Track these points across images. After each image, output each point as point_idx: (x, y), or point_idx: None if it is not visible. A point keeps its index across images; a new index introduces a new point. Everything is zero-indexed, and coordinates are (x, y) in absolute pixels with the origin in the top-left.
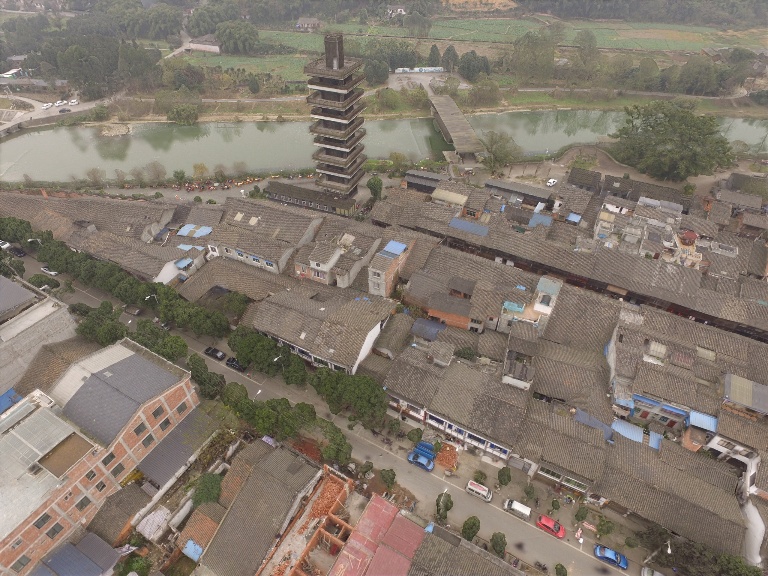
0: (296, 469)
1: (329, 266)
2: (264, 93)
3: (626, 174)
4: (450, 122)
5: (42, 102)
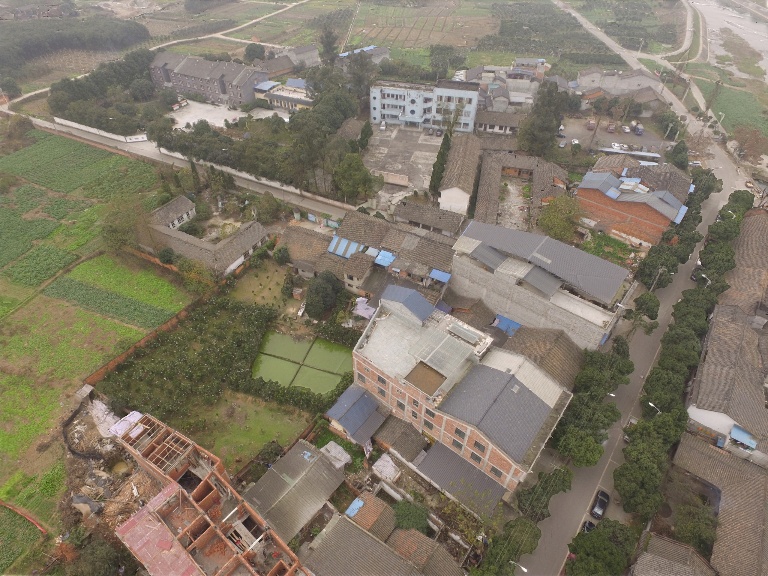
0: None
1: None
2: None
3: None
4: None
5: None
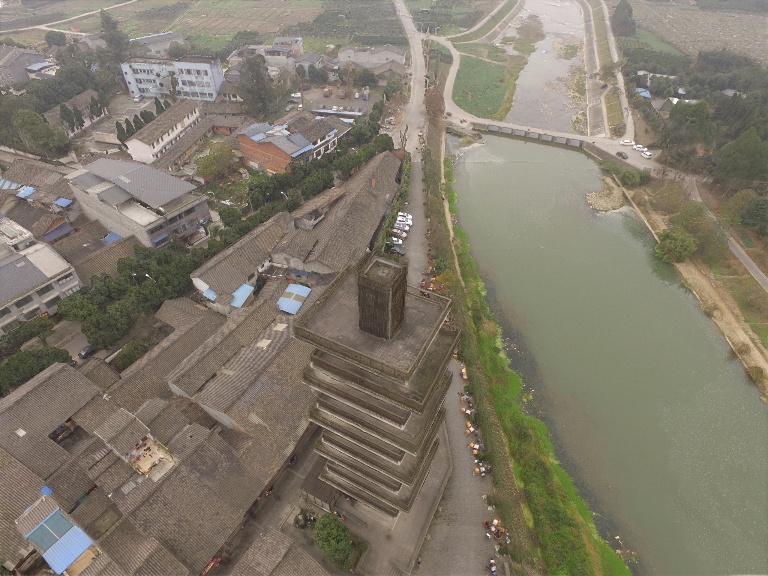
0: None
1: None
2: None
3: None
4: None
5: (635, 138)
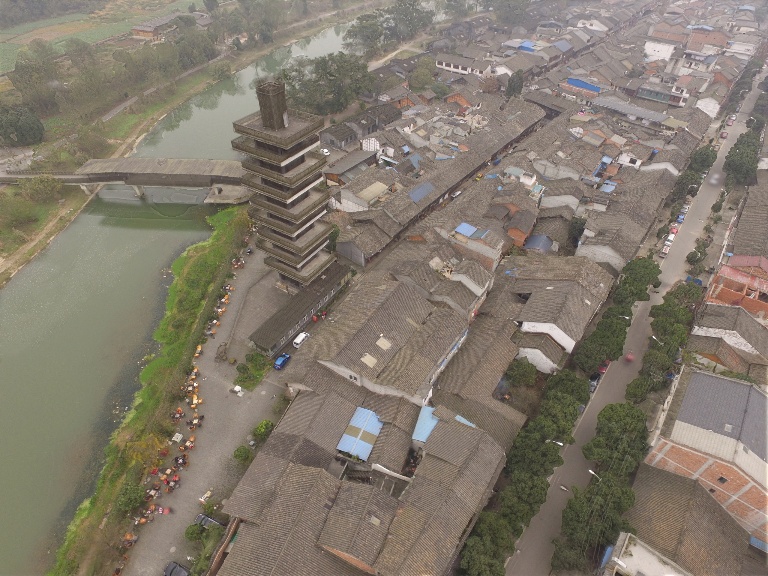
0: (719, 312)
1: None
2: None
3: (332, 119)
4: (182, 169)
5: None
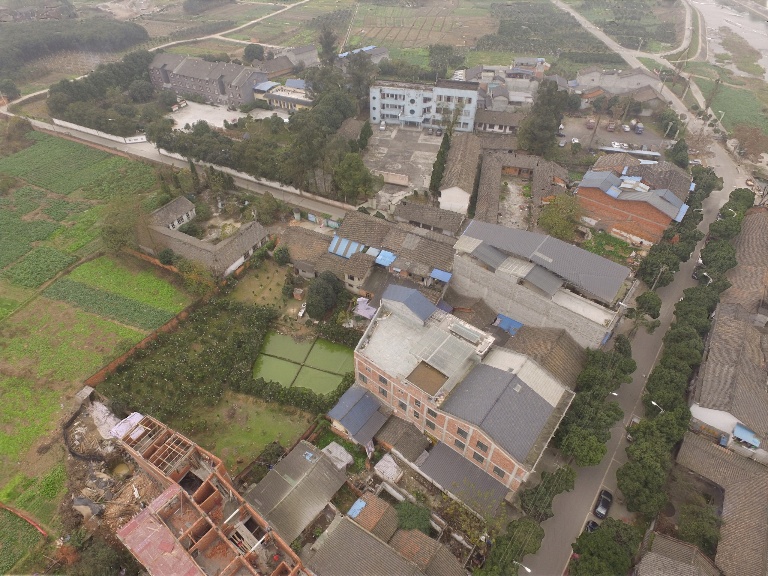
0: None
1: None
2: None
3: None
4: None
5: None
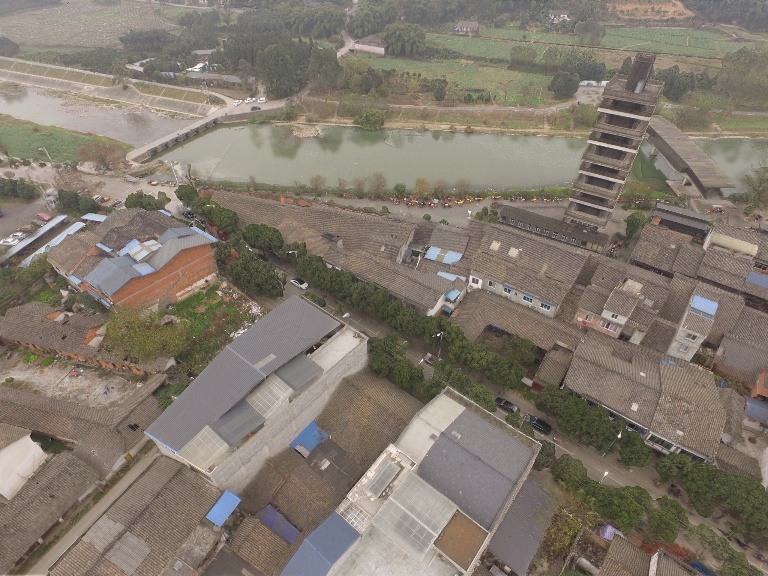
0: None
1: (626, 319)
2: (446, 101)
3: None
4: (681, 149)
5: (232, 98)
